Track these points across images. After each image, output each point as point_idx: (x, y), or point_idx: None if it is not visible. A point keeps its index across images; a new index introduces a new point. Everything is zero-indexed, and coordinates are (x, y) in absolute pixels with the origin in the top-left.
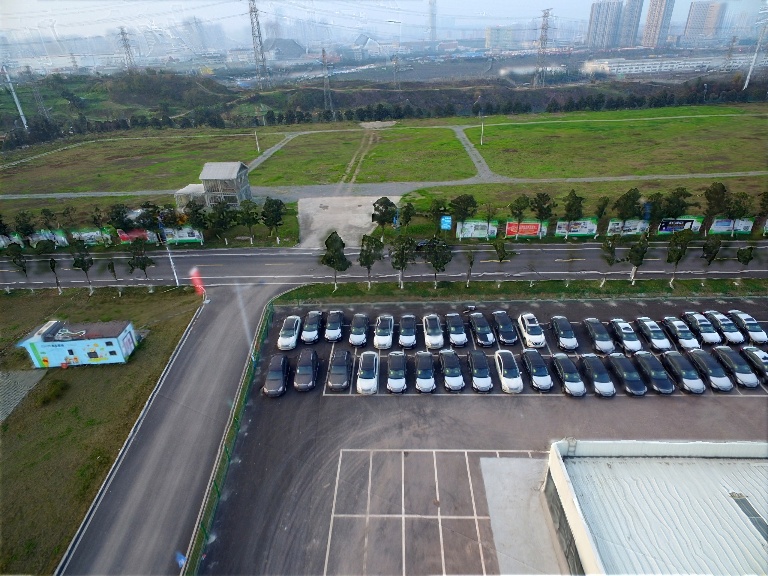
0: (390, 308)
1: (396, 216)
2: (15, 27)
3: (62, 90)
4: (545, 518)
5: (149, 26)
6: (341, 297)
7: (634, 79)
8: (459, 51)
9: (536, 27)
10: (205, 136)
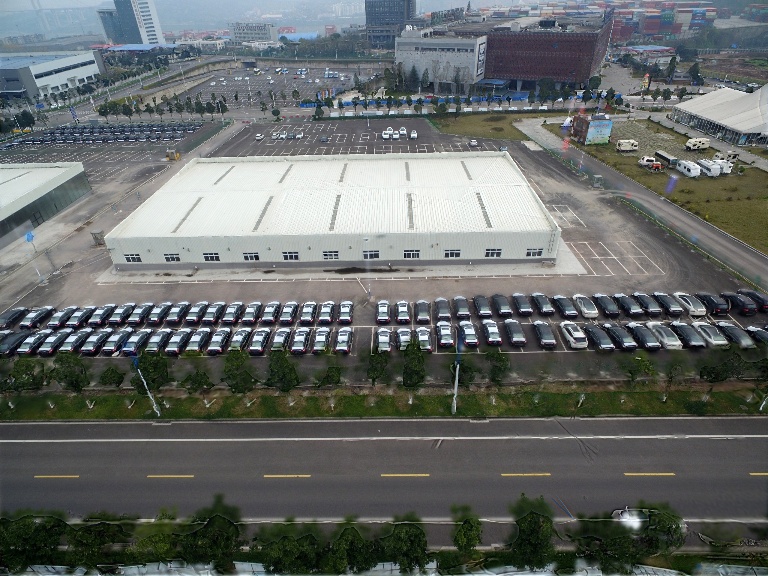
0: None
1: None
2: None
3: None
4: None
5: None
6: None
7: None
8: None
9: None
10: None
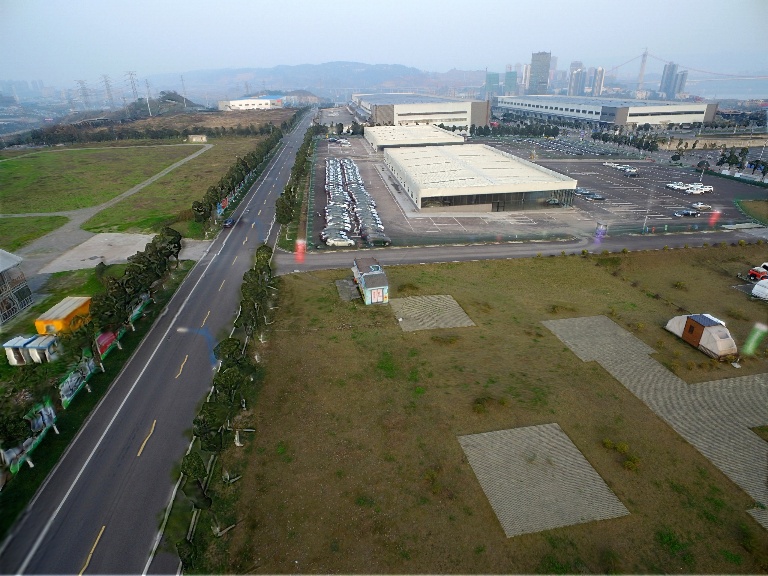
0: (311, 229)
1: None
2: None
3: None
4: (426, 212)
5: None
6: (298, 238)
7: None
8: None
9: None
10: None
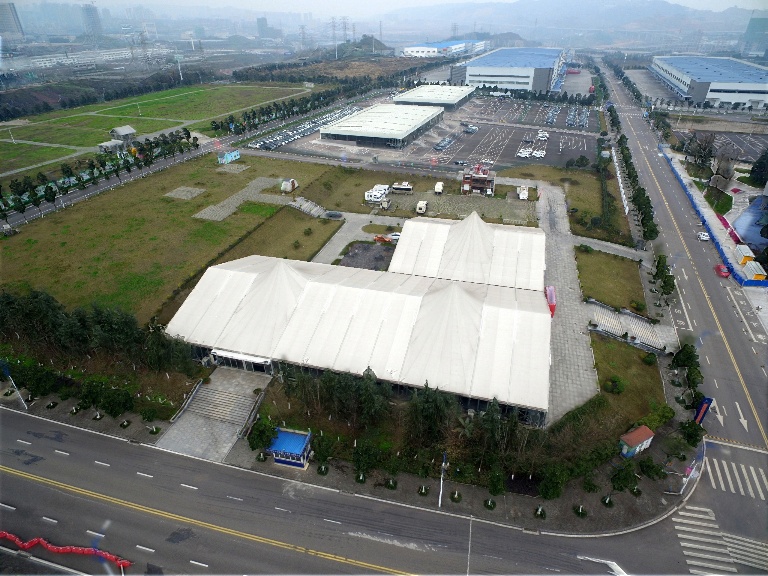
0: None
1: None
2: None
3: None
4: None
5: None
6: None
7: (78, 77)
8: None
9: None
10: None
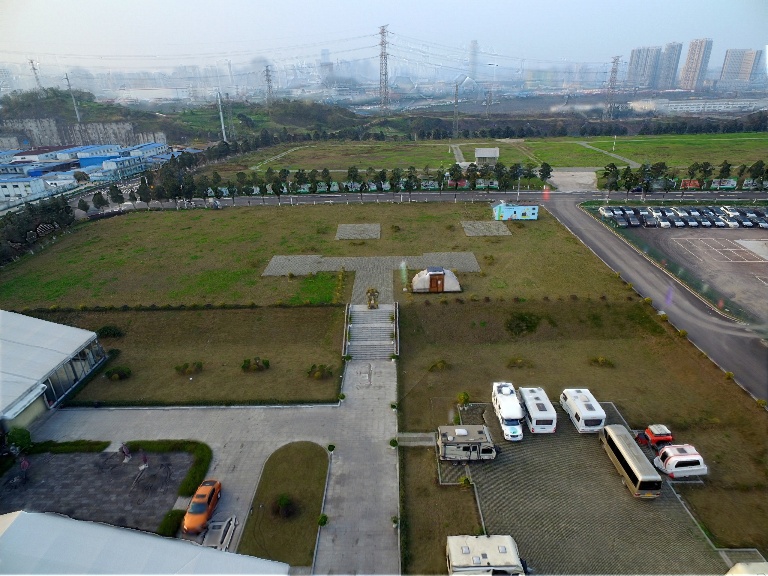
0: None
1: (619, 174)
2: (199, 64)
3: None
4: None
5: (295, 65)
6: None
7: (693, 115)
8: (540, 89)
9: (606, 70)
10: (385, 145)
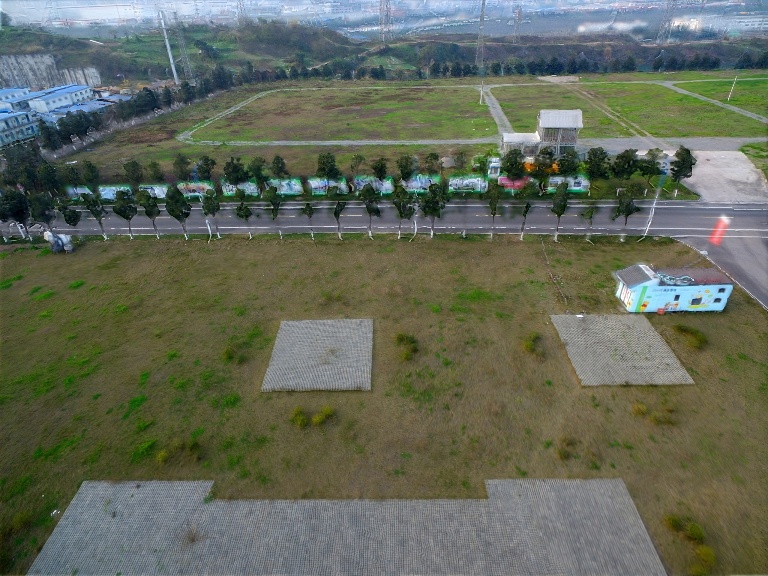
0: None
1: None
2: None
3: (189, 39)
4: None
5: None
6: None
7: None
8: (582, 2)
9: None
10: (386, 88)
